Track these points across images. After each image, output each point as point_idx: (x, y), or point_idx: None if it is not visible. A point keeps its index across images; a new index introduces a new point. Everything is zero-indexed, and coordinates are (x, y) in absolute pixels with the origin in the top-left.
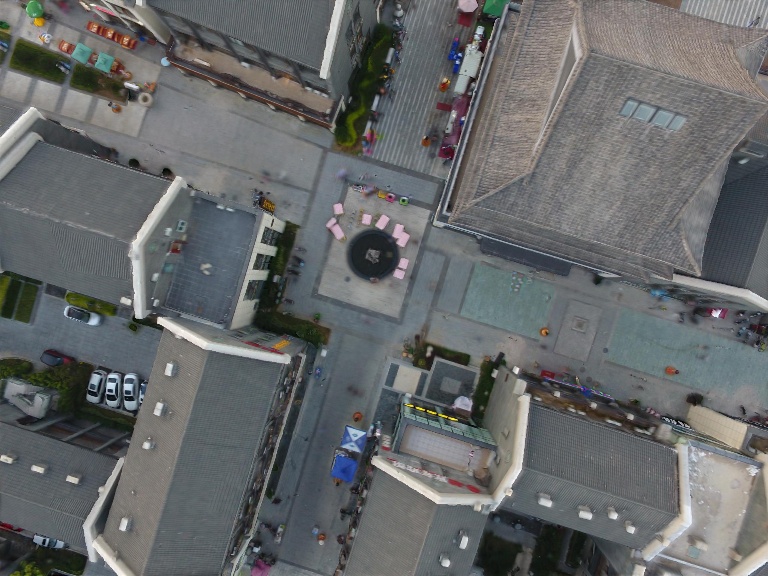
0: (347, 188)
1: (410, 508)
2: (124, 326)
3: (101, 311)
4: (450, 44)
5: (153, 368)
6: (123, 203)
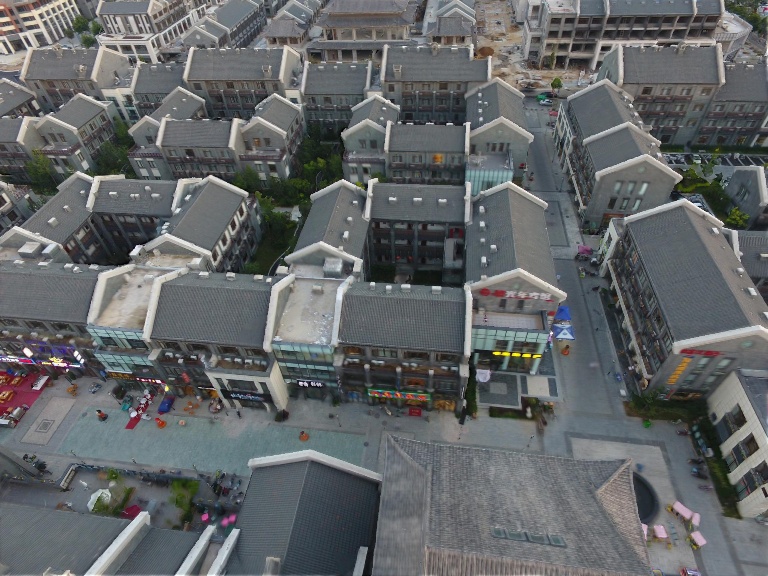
0: (702, 575)
1: (530, 269)
2: None
3: None
4: None
5: None
6: None
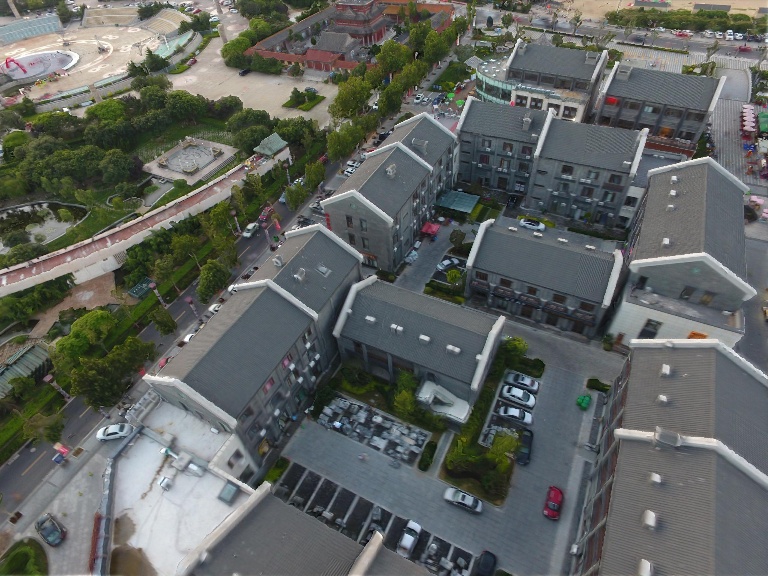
0: None
1: None
2: (560, 233)
3: (546, 223)
4: (742, 145)
5: (650, 190)
6: None
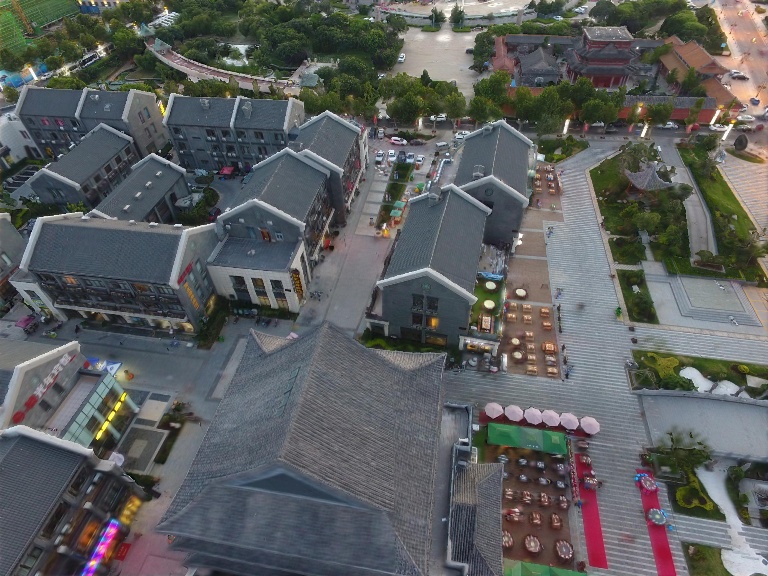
0: None
1: (23, 361)
2: None
3: None
4: None
5: None
6: (286, 201)
